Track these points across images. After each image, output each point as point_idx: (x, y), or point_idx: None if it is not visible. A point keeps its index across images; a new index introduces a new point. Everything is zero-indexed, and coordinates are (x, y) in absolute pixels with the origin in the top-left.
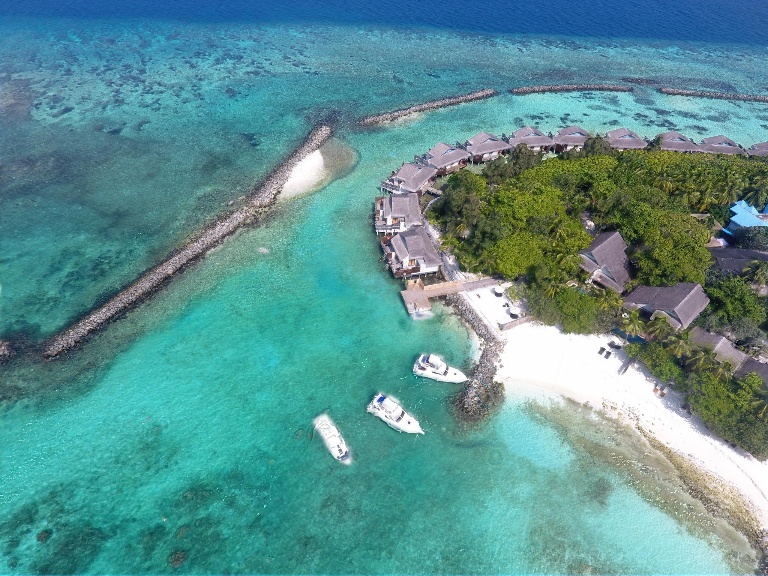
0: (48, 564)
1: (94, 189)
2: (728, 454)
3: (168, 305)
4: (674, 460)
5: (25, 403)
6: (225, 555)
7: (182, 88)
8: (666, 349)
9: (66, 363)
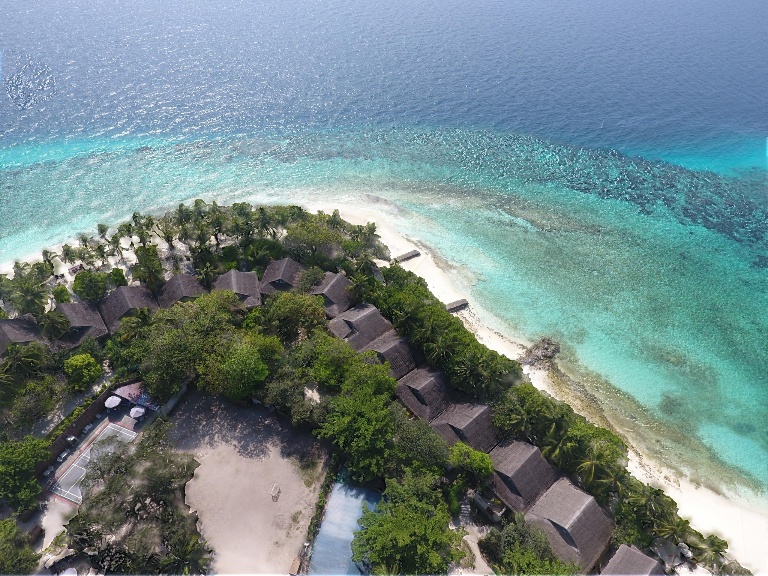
0: None
1: None
2: None
3: None
4: (607, 423)
5: None
6: None
7: None
8: None
9: None
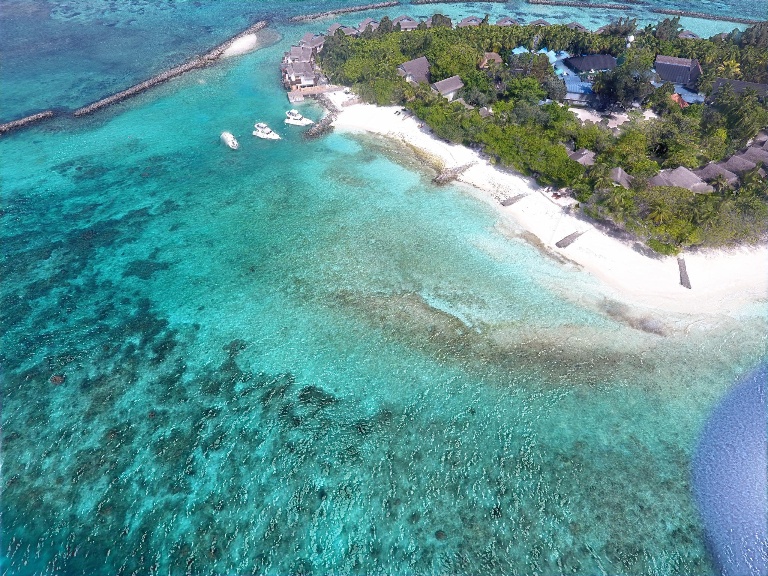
0: (82, 176)
1: (98, 52)
2: (444, 145)
3: (145, 99)
4: (415, 149)
5: (64, 132)
6: (169, 175)
7: (161, 2)
8: (423, 100)
9: (85, 119)
